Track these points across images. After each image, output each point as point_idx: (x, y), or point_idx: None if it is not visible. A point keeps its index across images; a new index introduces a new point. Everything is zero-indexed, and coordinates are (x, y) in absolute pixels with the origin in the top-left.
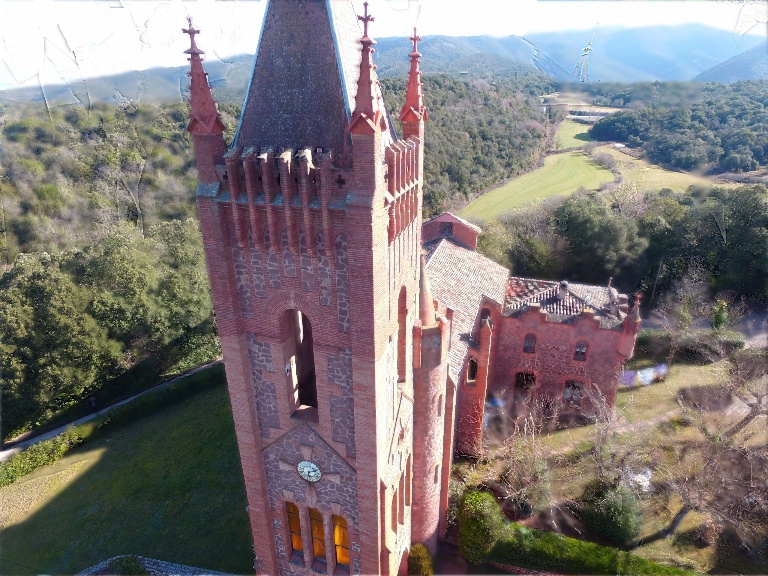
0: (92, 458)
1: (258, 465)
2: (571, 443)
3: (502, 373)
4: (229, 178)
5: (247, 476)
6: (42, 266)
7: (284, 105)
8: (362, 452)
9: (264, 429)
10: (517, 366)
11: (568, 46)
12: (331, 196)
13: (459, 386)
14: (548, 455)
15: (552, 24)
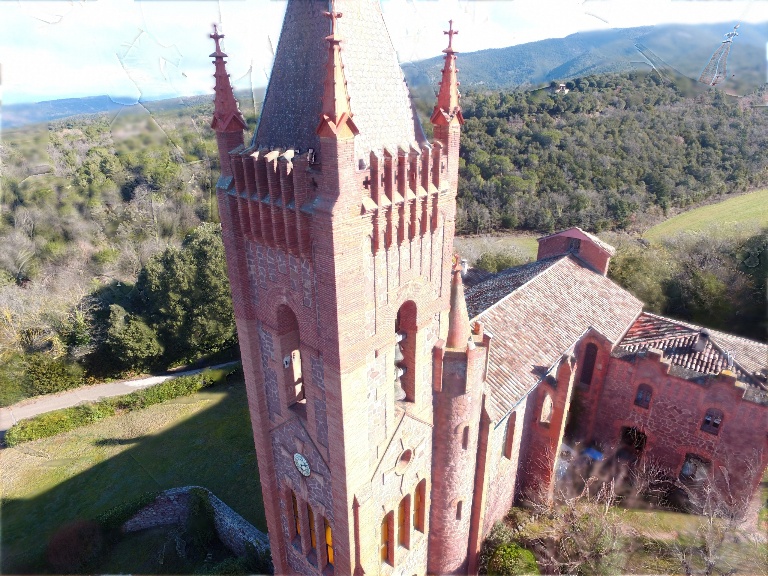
0: (215, 399)
1: (265, 444)
2: (675, 531)
3: (604, 422)
4: (234, 173)
5: (258, 451)
6: (212, 234)
7: (290, 105)
8: (334, 461)
9: (271, 412)
10: (624, 419)
11: (707, 31)
12: (307, 198)
13: (530, 423)
14: (621, 534)
15: (693, 4)
